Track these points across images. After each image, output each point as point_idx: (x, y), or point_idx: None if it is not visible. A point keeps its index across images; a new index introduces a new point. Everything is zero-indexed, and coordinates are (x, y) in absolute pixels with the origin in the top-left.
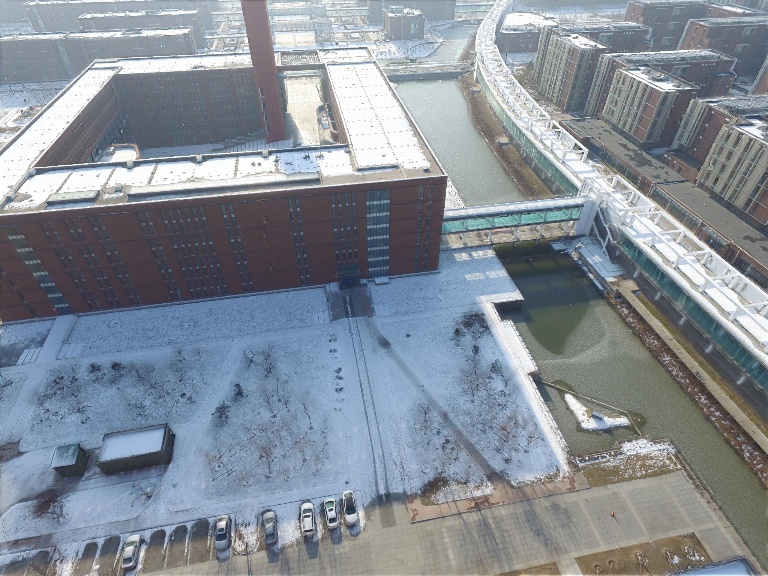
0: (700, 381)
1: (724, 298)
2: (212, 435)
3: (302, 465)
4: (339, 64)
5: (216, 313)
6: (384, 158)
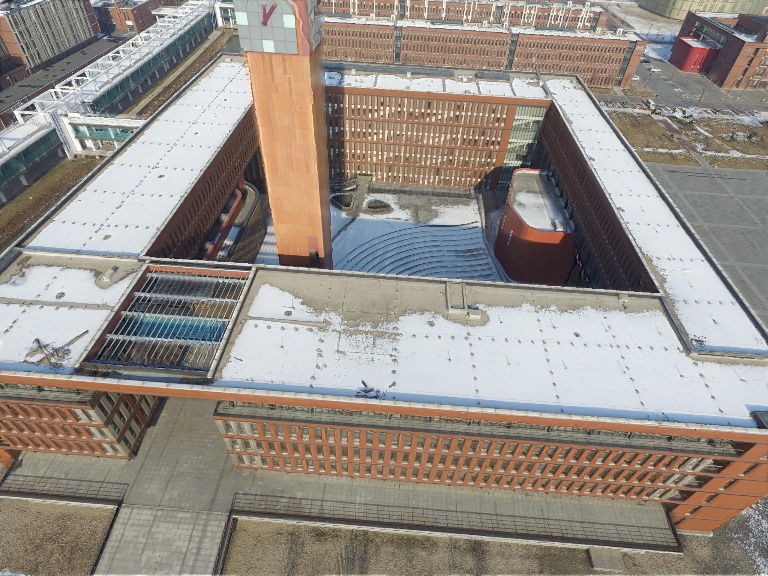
0: None
1: None
2: None
3: None
4: (109, 256)
5: None
6: None
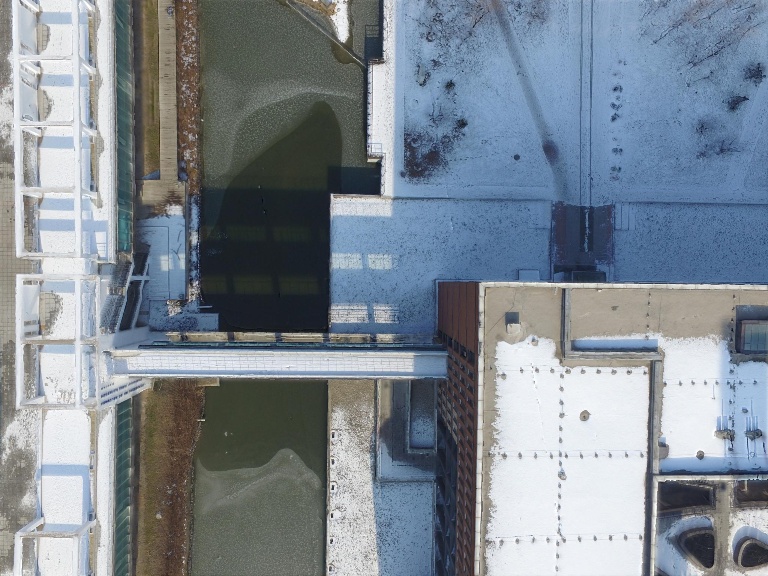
0: (176, 7)
1: (68, 50)
2: (759, 59)
3: (668, 1)
4: None
5: (765, 256)
6: (588, 401)
